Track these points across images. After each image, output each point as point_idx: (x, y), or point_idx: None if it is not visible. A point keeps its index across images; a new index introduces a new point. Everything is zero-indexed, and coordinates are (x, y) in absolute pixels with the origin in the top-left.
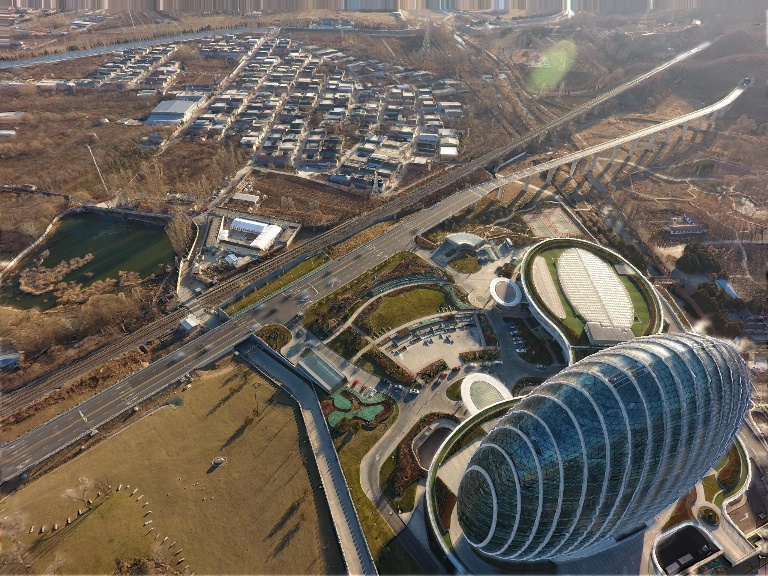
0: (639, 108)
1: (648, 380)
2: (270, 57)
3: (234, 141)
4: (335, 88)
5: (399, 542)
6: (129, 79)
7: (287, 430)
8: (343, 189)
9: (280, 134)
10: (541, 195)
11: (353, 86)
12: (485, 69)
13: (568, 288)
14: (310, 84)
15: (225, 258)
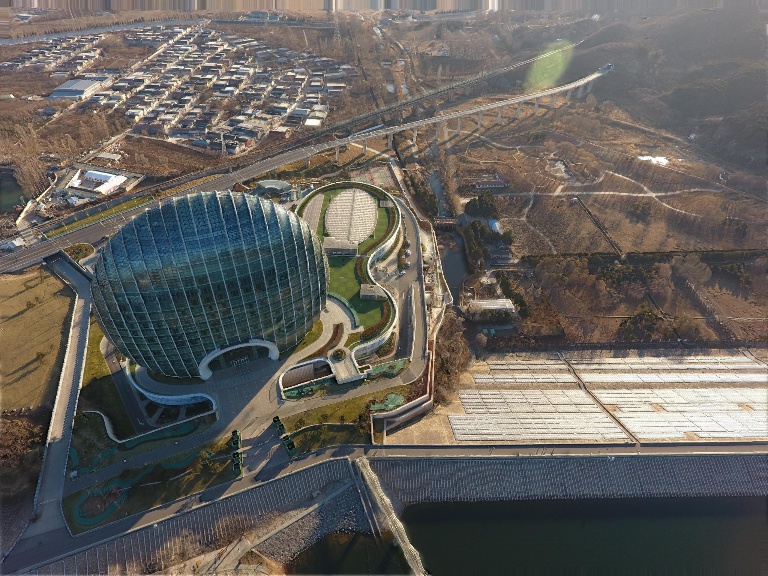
0: (509, 90)
1: (170, 208)
2: (187, 45)
3: (119, 113)
4: (234, 71)
5: (111, 378)
6: (47, 63)
7: (59, 311)
8: (200, 151)
9: (165, 108)
10: (377, 157)
11: (253, 70)
12: (387, 57)
13: (329, 216)
14: (213, 68)
15: (67, 199)
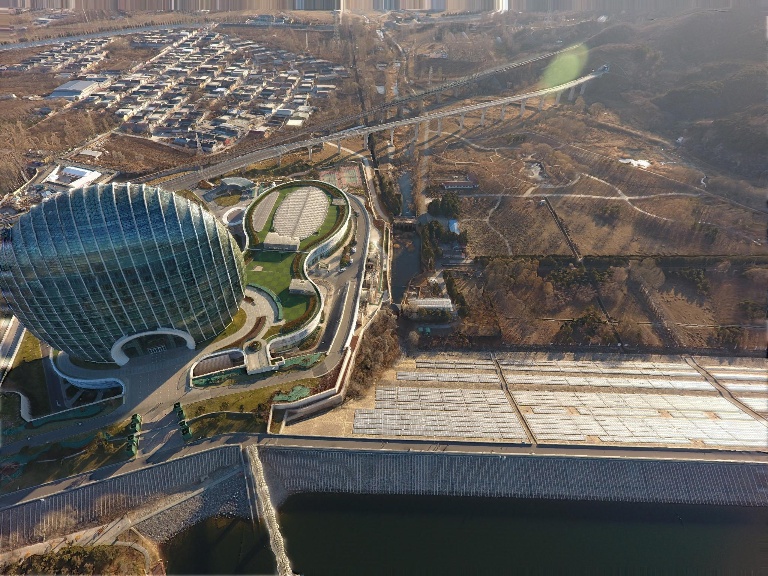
0: (500, 92)
1: (65, 198)
2: (190, 47)
3: (109, 112)
4: (229, 73)
5: (40, 361)
6: (54, 64)
7: None
8: (178, 149)
9: (154, 108)
10: (350, 157)
11: (248, 71)
12: (384, 59)
13: (280, 212)
14: (209, 69)
15: (41, 193)
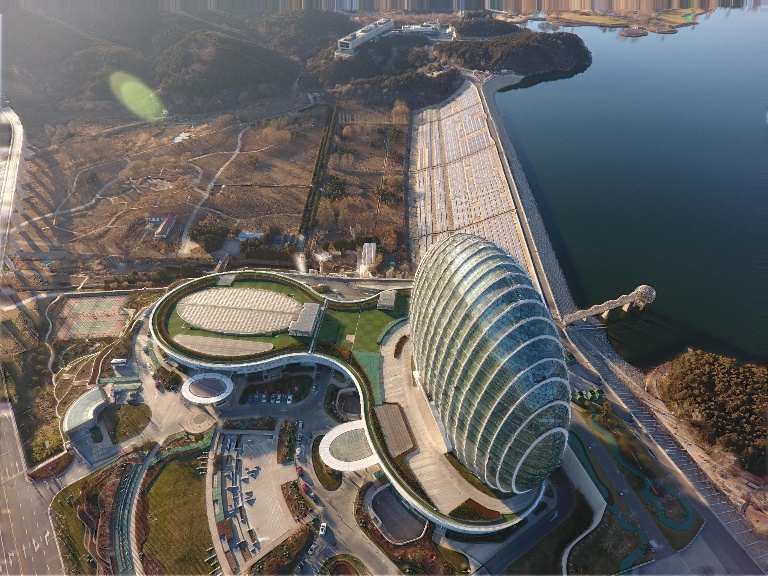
0: None
1: (521, 278)
2: None
3: None
4: None
5: None
6: None
7: None
8: None
9: None
10: (30, 308)
11: None
12: None
13: (234, 329)
14: None
15: None
